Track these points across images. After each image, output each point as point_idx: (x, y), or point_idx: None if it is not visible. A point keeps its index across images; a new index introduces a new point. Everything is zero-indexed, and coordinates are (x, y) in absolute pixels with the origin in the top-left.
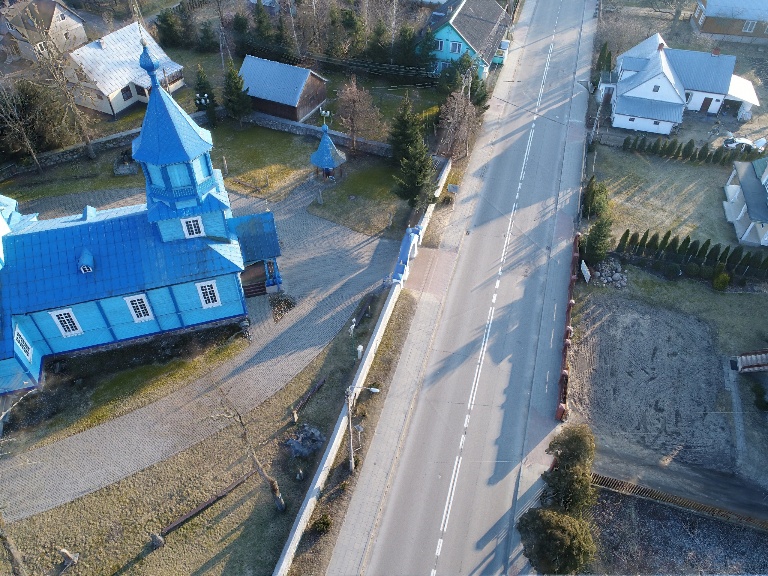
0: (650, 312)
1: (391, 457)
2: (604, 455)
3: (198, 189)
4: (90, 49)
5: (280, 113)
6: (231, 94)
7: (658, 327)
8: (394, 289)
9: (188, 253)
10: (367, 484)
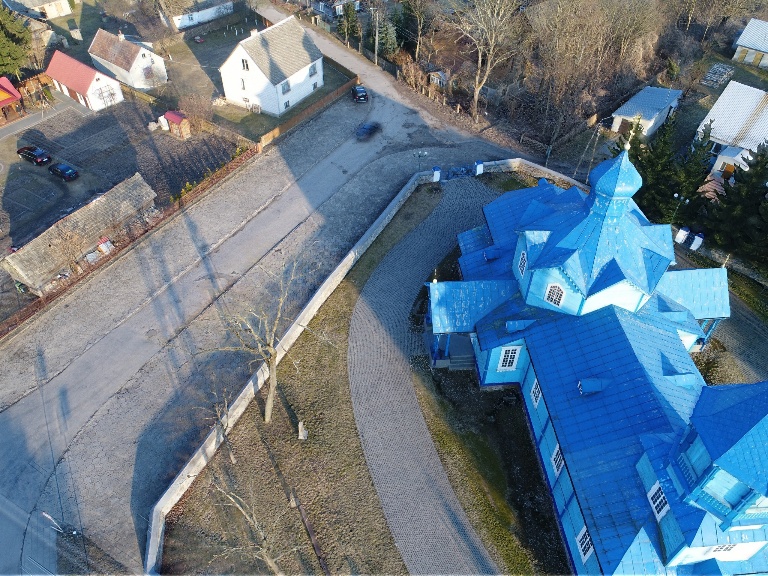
0: None
1: None
2: None
3: (699, 491)
4: None
5: None
6: None
7: None
8: None
9: (624, 500)
10: None
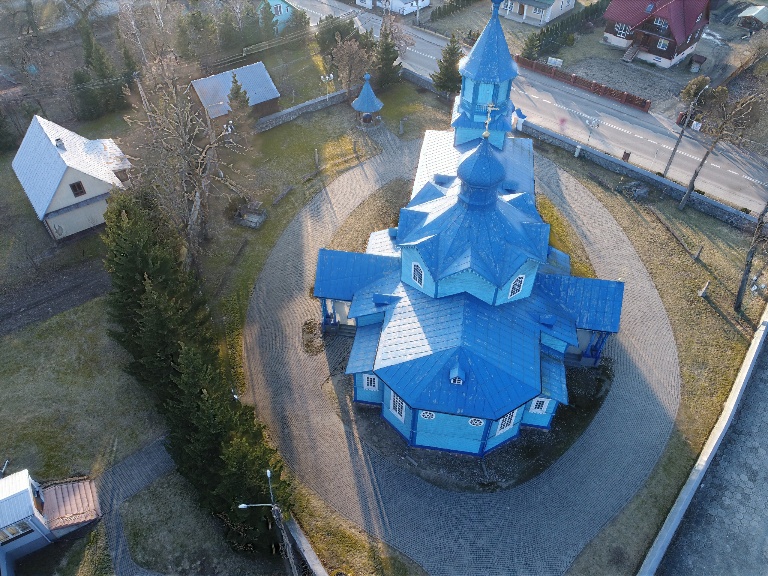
0: (579, 67)
1: (658, 164)
2: (670, 110)
3: None
4: (64, 155)
5: (261, 114)
6: (243, 110)
7: (591, 69)
8: (531, 123)
9: (514, 148)
10: (674, 175)
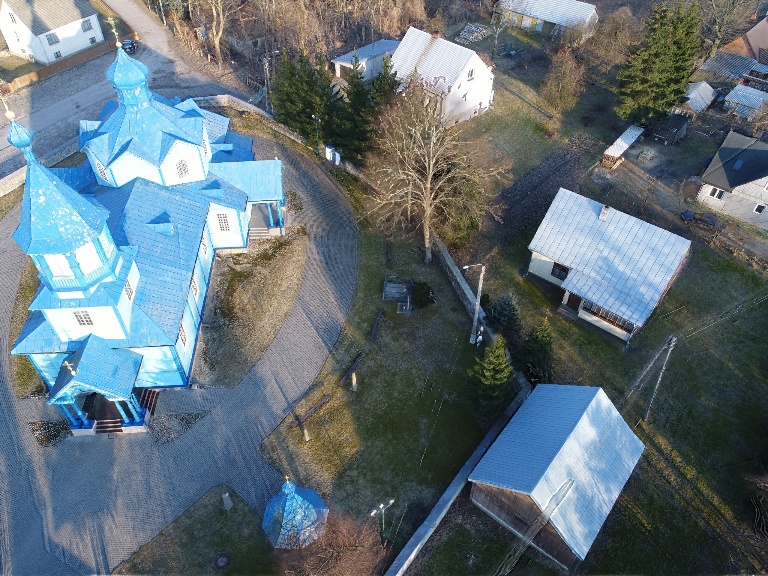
0: None
1: None
2: None
3: None
4: (587, 205)
5: None
6: None
7: None
8: None
9: None
10: None
